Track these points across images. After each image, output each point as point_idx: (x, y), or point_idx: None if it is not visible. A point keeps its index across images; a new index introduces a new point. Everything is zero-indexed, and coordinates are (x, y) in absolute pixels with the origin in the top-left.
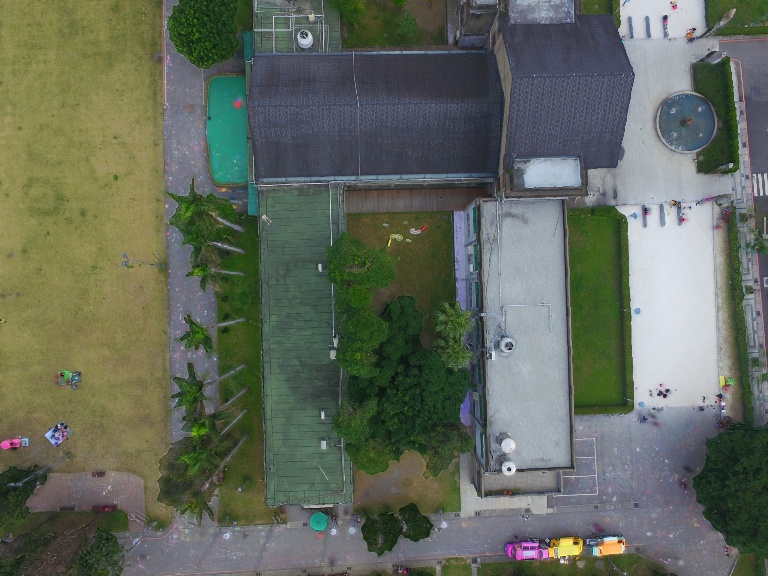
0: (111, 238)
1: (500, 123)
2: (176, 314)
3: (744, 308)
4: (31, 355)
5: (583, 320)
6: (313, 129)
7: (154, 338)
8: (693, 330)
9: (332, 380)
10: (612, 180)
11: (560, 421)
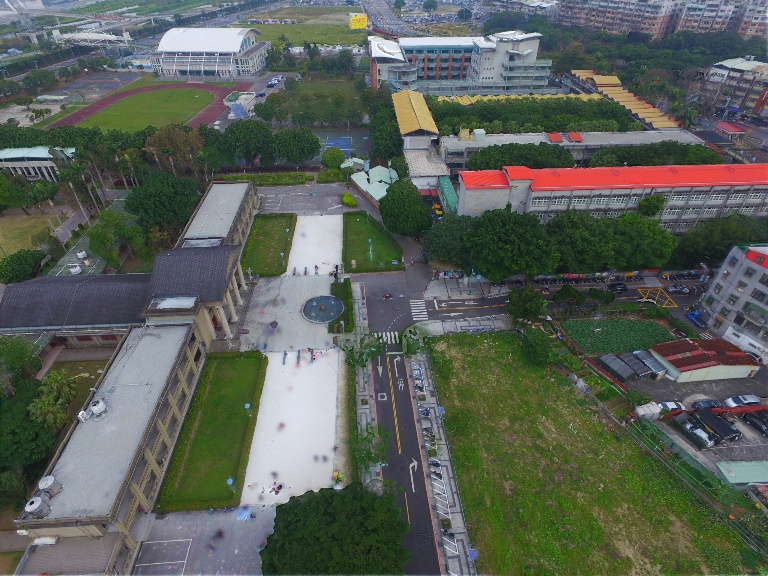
0: None
1: None
2: None
3: (360, 415)
4: None
5: (215, 428)
6: (43, 299)
7: None
8: (314, 435)
9: None
10: (265, 339)
11: (120, 473)
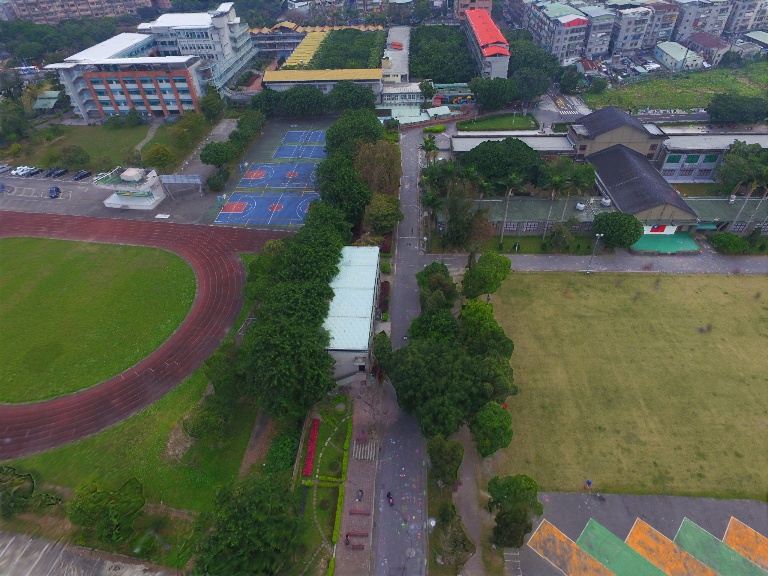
0: None
1: (627, 148)
2: None
3: None
4: None
5: None
6: None
7: None
8: None
9: None
10: None
11: None
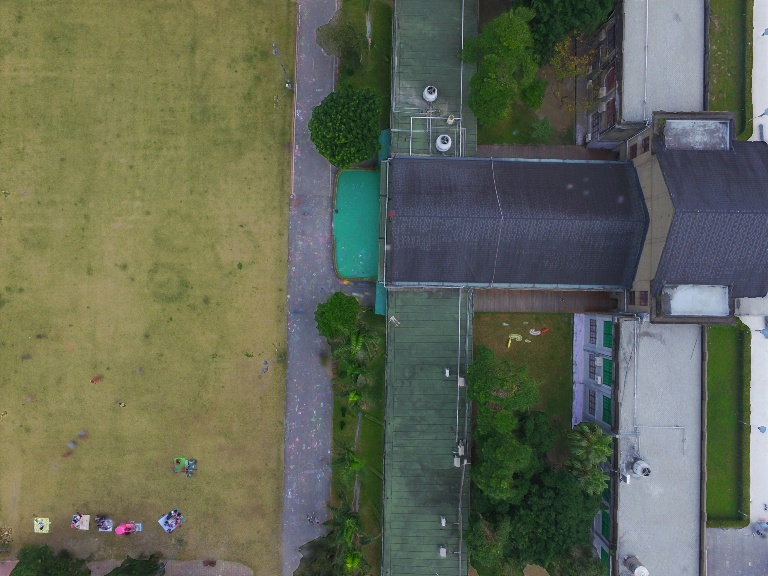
0: (233, 326)
1: (641, 241)
2: (293, 405)
3: None
4: (148, 440)
5: None
6: (453, 239)
7: (270, 428)
8: None
9: (453, 486)
10: None
11: (689, 546)
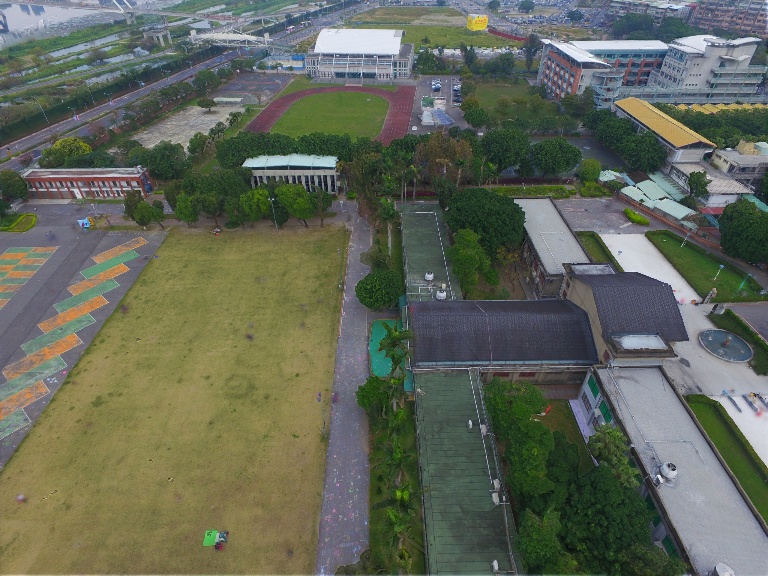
0: (285, 415)
1: (588, 327)
2: (332, 478)
3: None
4: (185, 513)
5: None
6: (456, 330)
7: (308, 500)
8: None
9: (498, 528)
10: (690, 380)
11: None
